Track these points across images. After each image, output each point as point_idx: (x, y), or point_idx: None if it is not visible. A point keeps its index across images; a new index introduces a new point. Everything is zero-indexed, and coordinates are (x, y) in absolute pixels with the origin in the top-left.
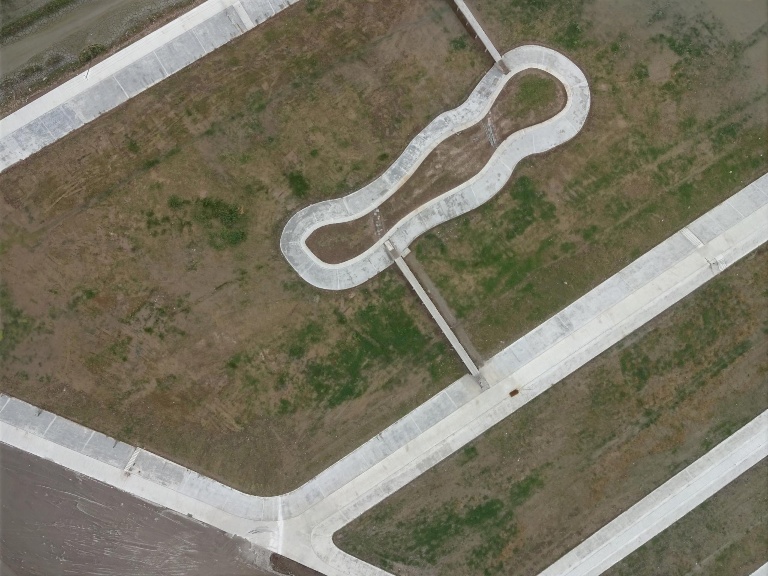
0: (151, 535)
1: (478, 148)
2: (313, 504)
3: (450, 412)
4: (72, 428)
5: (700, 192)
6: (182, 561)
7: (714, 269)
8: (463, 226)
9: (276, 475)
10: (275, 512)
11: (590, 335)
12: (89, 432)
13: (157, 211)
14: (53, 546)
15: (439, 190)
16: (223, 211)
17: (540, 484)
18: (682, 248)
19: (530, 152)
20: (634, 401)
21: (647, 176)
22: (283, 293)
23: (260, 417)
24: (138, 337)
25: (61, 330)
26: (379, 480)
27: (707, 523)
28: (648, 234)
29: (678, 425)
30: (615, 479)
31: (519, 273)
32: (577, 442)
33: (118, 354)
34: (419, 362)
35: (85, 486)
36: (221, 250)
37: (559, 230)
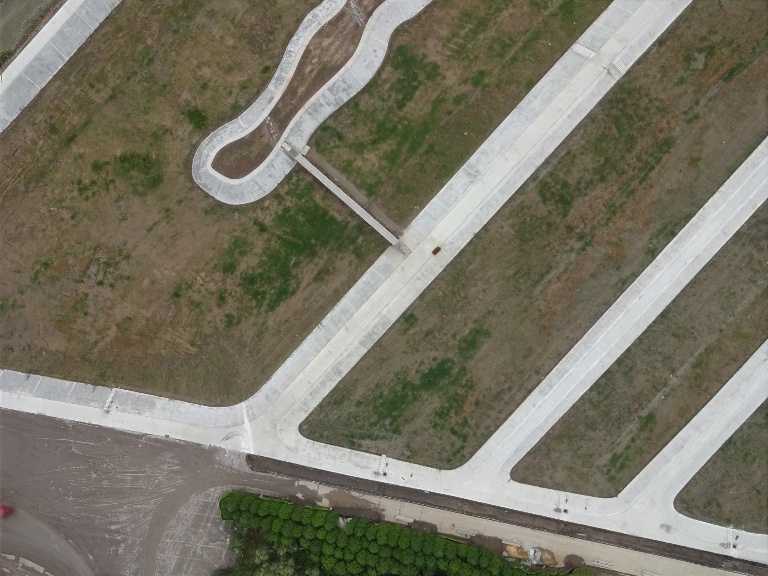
0: (138, 461)
1: (347, 32)
2: (272, 401)
3: (379, 285)
4: (56, 384)
5: (582, 4)
6: (170, 479)
7: (614, 74)
8: (353, 110)
9: (236, 384)
10: (241, 417)
11: (499, 175)
12: (70, 384)
13: (84, 178)
14: (61, 488)
15: (320, 82)
16: (137, 161)
17: (486, 333)
18: (575, 64)
19: (400, 21)
20: (563, 228)
21: (523, 6)
22: (205, 219)
23: (210, 335)
24: (93, 292)
25: (30, 303)
26: (327, 365)
27: (672, 332)
28: (538, 62)
29: (616, 240)
30: (562, 310)
31: (417, 138)
32: (514, 283)
33: (80, 311)
34: (342, 248)
35: (75, 430)
36: (144, 196)
37: (447, 85)
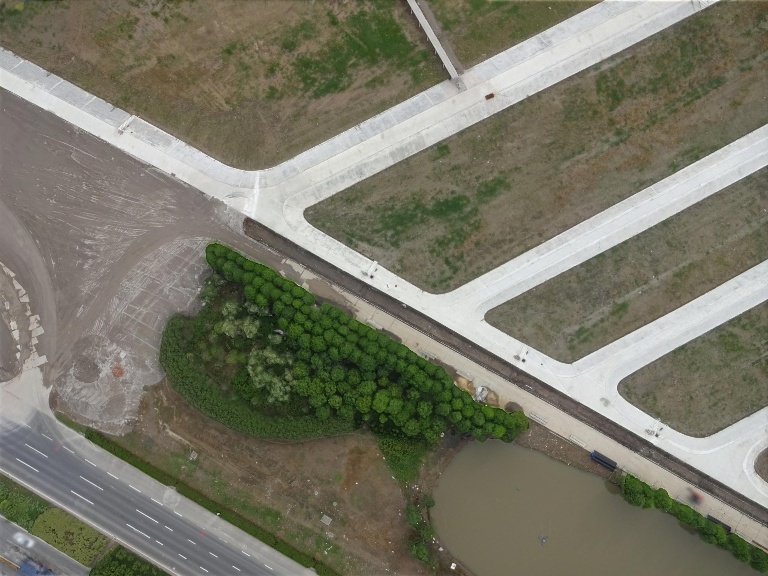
0: (136, 188)
1: None
2: (289, 177)
3: (427, 108)
4: (76, 91)
5: None
6: (161, 215)
7: (695, 5)
8: None
9: (257, 152)
10: (252, 182)
11: (568, 52)
12: (90, 96)
13: None
14: (46, 188)
15: None
16: None
17: (507, 186)
18: None
19: None
20: (606, 120)
21: None
22: None
23: (248, 100)
24: (145, 19)
25: (76, 7)
26: (353, 162)
27: (668, 240)
28: None
29: (647, 146)
30: (581, 189)
31: None
32: (547, 151)
33: (125, 32)
34: (402, 66)
35: (81, 139)
36: None
37: None
